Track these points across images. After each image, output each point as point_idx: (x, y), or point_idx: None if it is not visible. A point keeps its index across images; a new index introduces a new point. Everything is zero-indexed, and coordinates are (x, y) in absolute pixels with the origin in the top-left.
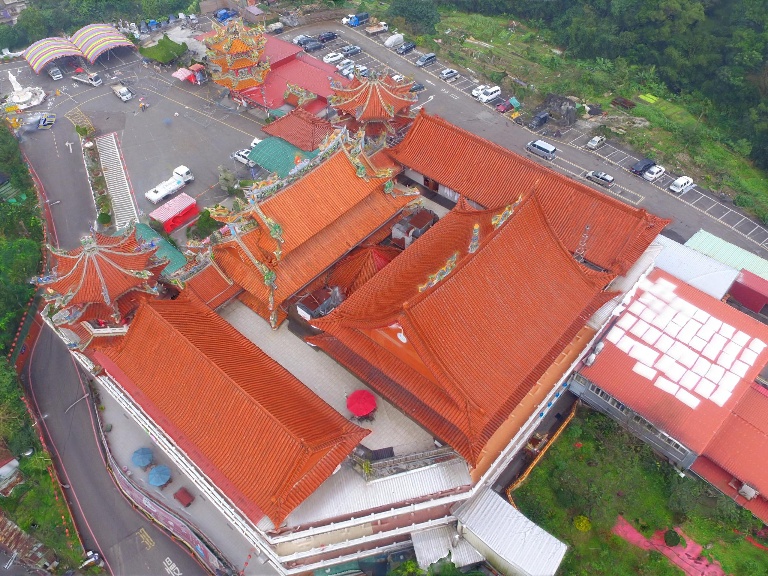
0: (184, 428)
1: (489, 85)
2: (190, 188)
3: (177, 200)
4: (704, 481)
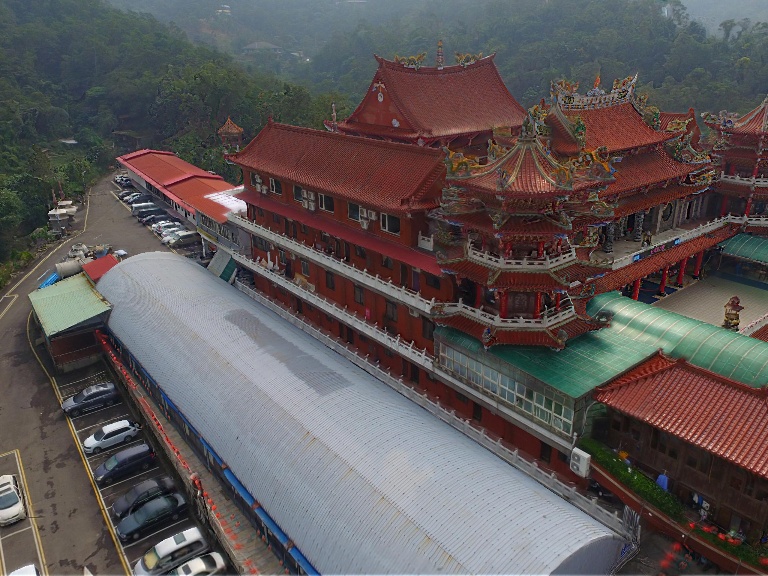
0: None
1: None
2: None
3: None
4: None
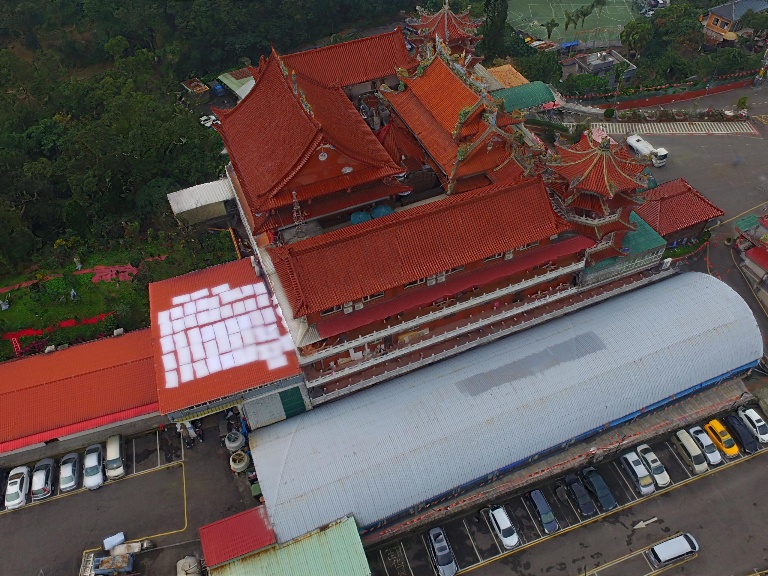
0: None
1: None
2: None
3: None
4: (150, 326)
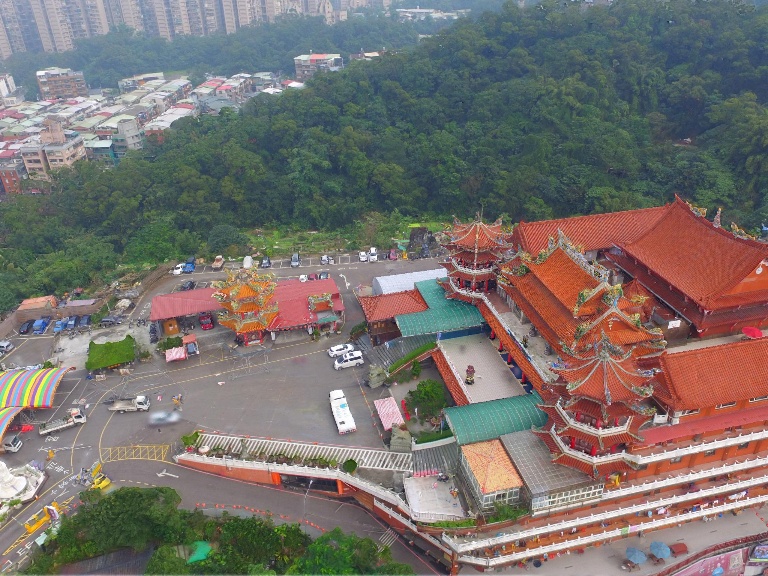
0: (763, 393)
1: (359, 252)
2: (351, 406)
3: (387, 404)
4: None
